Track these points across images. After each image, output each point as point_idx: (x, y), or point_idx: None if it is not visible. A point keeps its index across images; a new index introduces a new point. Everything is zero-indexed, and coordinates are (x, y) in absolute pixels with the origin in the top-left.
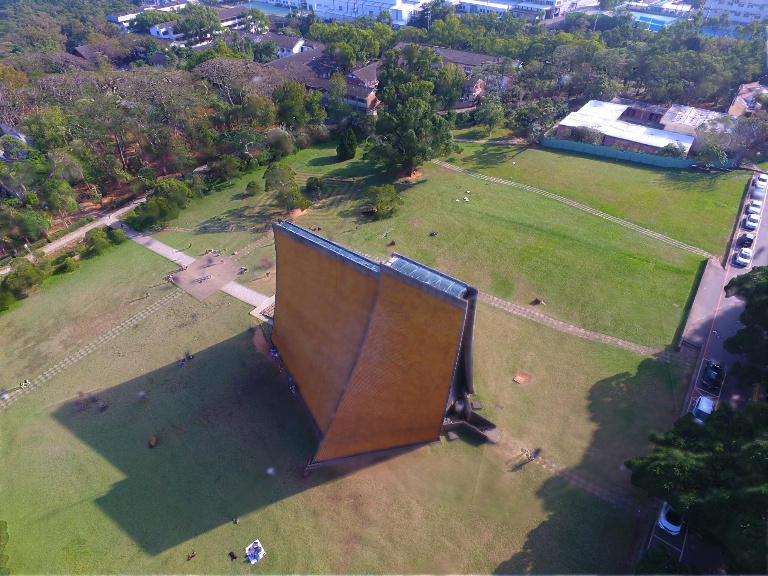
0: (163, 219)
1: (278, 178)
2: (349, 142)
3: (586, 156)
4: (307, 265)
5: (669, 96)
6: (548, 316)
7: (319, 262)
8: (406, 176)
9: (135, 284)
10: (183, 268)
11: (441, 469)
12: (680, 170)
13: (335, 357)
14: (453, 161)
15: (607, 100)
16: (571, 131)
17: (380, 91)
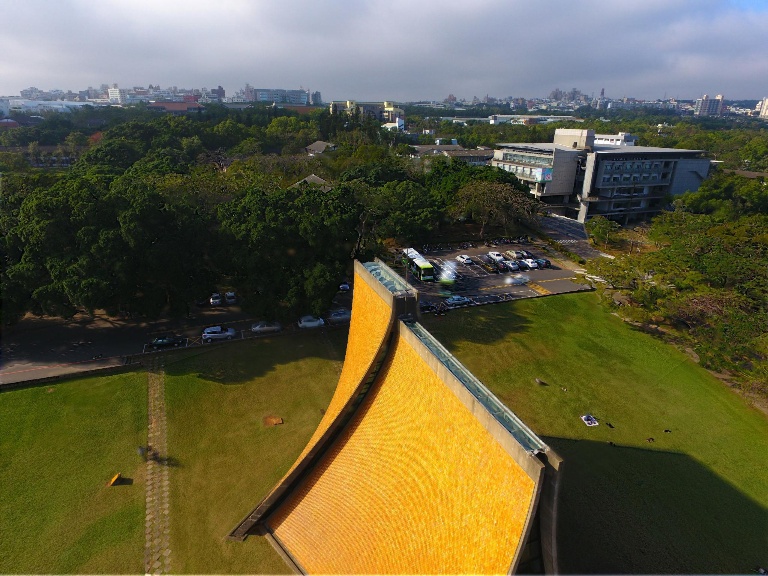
0: None
1: None
2: None
3: None
4: None
5: None
6: (147, 457)
7: None
8: None
9: None
10: None
11: None
12: None
13: None
14: None
15: None
16: None
17: None
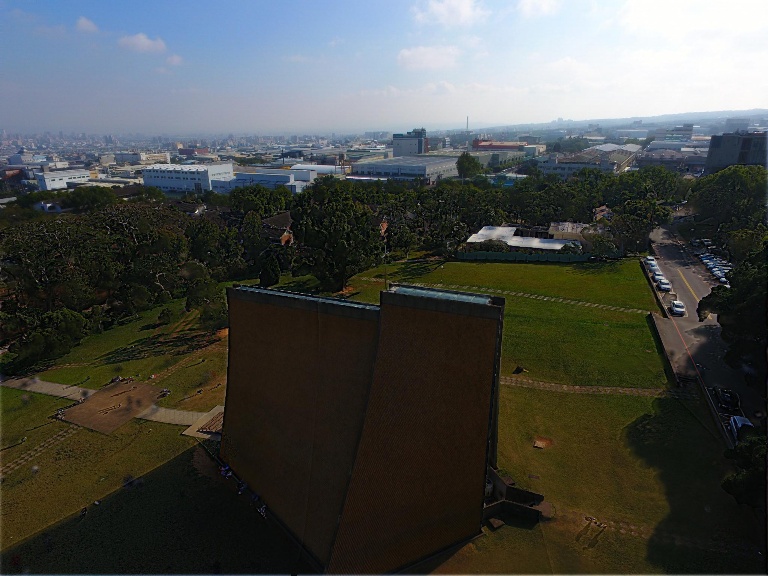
0: (47, 359)
1: (202, 294)
2: (272, 268)
3: (500, 262)
4: (275, 332)
5: (545, 219)
6: (537, 381)
7: (292, 322)
8: (338, 291)
9: (3, 430)
10: (79, 401)
11: (500, 569)
12: (582, 262)
13: (325, 442)
14: (381, 276)
15: (497, 226)
16: (480, 245)
17: (296, 226)
